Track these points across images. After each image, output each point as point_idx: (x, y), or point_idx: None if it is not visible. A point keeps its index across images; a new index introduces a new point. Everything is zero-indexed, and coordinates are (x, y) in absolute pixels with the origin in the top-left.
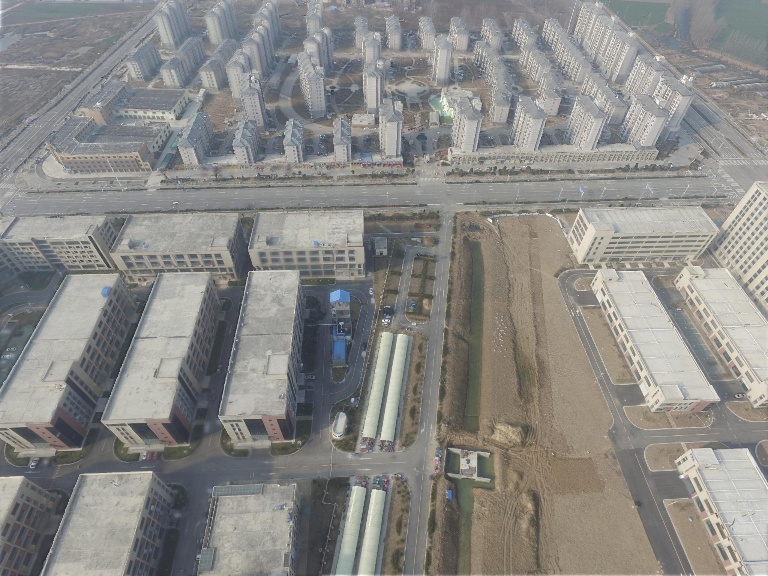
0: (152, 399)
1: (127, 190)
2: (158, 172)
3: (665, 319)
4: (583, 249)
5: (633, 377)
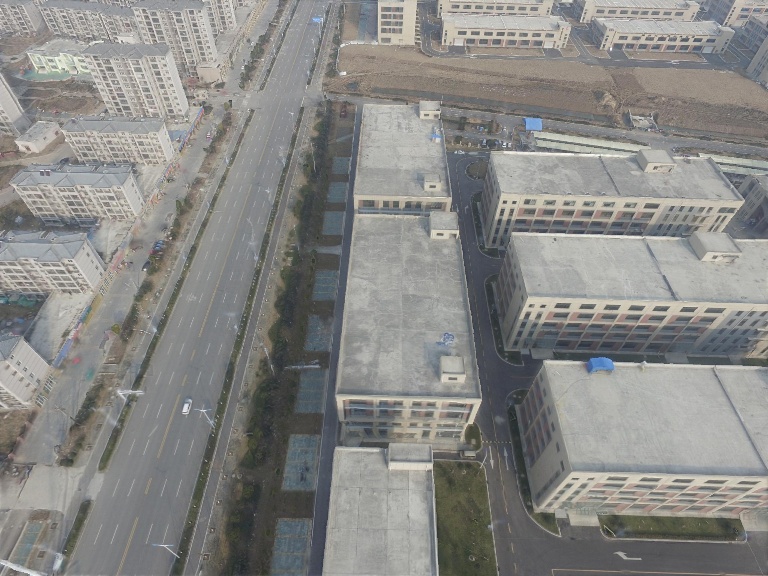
0: (762, 263)
1: (63, 563)
2: (3, 487)
3: (492, 17)
4: (410, 29)
5: (536, 48)
